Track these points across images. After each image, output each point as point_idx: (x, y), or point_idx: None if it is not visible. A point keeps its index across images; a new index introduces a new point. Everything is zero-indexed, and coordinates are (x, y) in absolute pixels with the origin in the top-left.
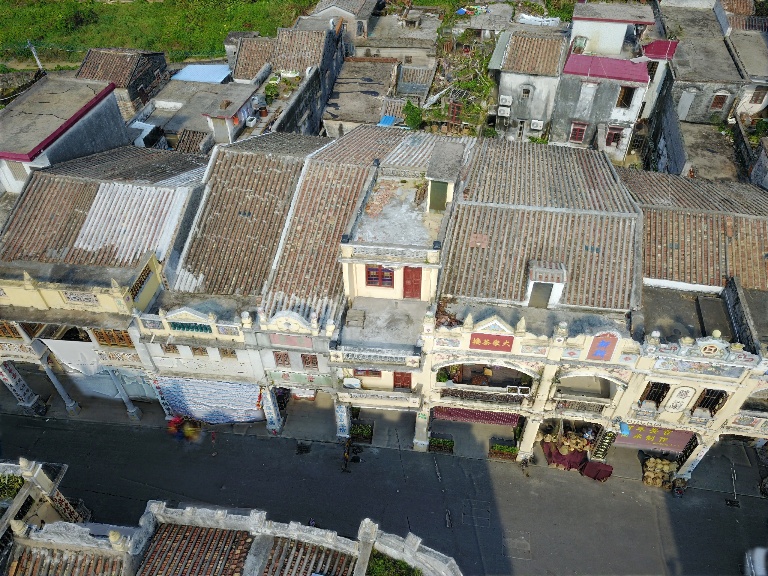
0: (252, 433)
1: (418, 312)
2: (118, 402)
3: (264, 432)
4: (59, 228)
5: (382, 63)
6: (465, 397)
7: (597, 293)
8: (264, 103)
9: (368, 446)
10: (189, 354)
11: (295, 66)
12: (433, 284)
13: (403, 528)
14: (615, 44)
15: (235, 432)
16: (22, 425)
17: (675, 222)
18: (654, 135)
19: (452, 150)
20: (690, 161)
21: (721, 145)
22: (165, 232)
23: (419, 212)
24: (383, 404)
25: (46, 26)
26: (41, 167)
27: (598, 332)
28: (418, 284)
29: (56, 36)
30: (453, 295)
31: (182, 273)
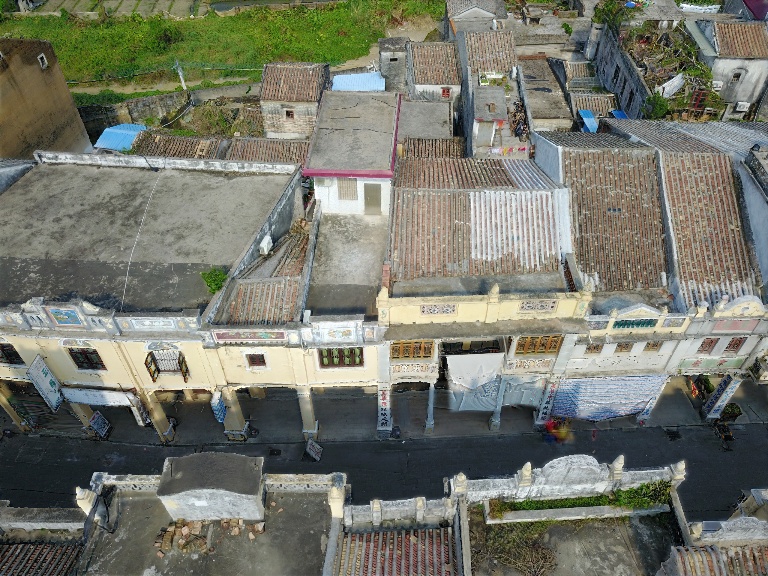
0: (617, 427)
1: None
2: (465, 414)
3: (628, 424)
4: (447, 241)
5: (532, 60)
6: None
7: None
8: None
9: (732, 424)
10: (611, 352)
11: (493, 67)
12: None
13: None
14: None
15: (600, 428)
16: (381, 450)
17: None
18: None
19: None
20: None
21: None
22: (563, 234)
23: None
24: None
25: (134, 47)
26: None
27: None
28: None
29: (151, 56)
30: None
31: None
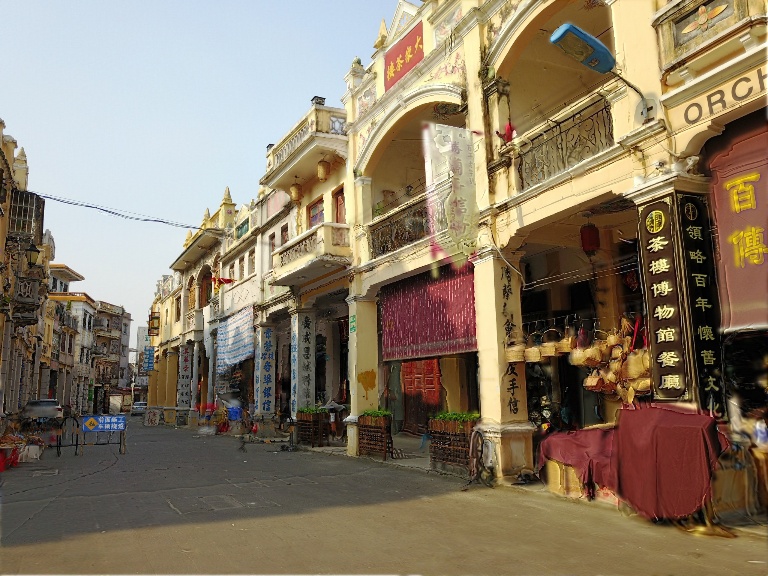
0: None
1: None
2: None
3: None
4: None
5: None
6: (398, 245)
7: None
8: None
9: (308, 449)
10: None
11: None
12: None
13: (166, 466)
14: None
15: None
16: None
17: None
18: None
19: None
20: None
21: None
22: None
23: None
24: None
25: None
26: None
27: None
28: None
29: None
30: None
31: None
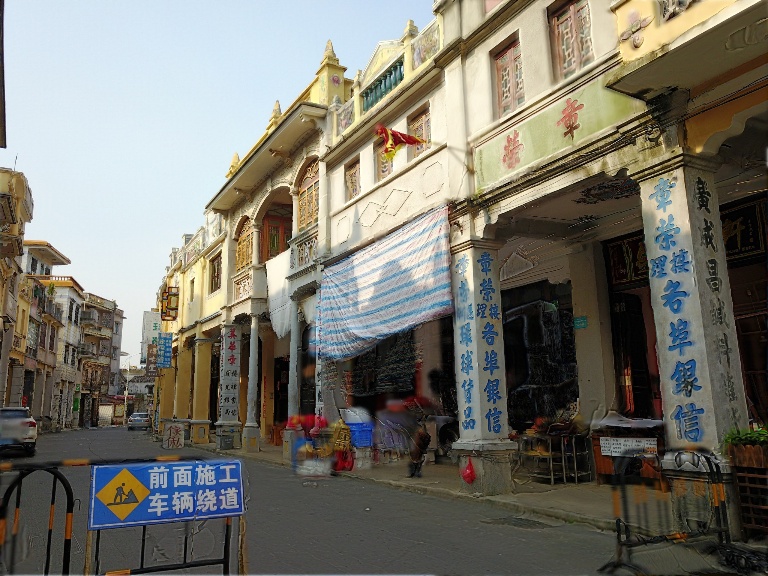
0: None
1: None
2: None
3: None
4: None
5: None
6: None
7: None
8: None
9: None
10: (371, 179)
11: None
12: None
13: None
14: None
15: None
16: None
17: None
18: None
19: None
20: None
21: None
22: None
23: None
24: None
25: None
26: None
27: None
28: None
29: None
30: None
31: None
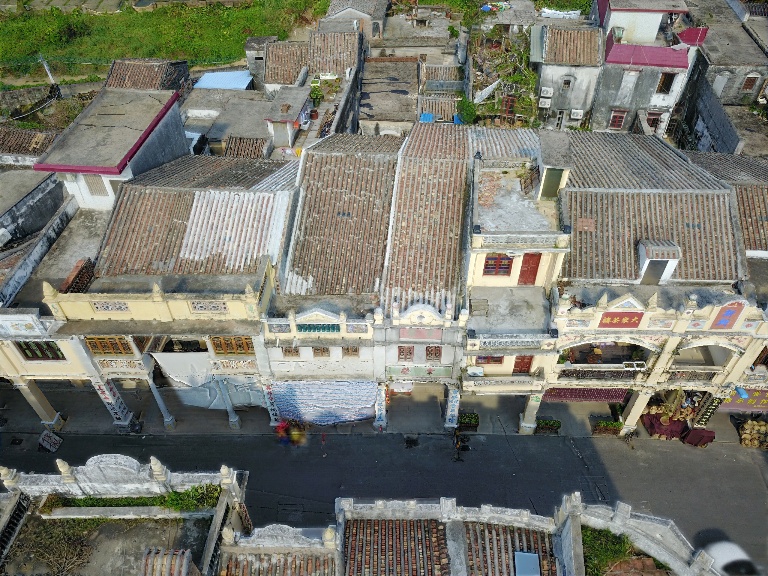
0: (357, 432)
1: (535, 297)
2: (213, 413)
3: (369, 430)
4: (160, 239)
5: (403, 62)
6: (581, 376)
7: (706, 267)
8: (311, 106)
9: (474, 434)
10: (310, 356)
11: (332, 68)
12: (557, 268)
13: None
14: (650, 33)
15: (340, 432)
16: (118, 444)
17: (760, 196)
18: (687, 118)
19: (558, 139)
20: (744, 140)
21: (757, 124)
22: (273, 236)
23: (530, 200)
24: (506, 389)
25: (38, 40)
26: (123, 180)
27: (728, 302)
28: (533, 270)
29: (51, 50)
30: (568, 278)
31: (291, 276)
